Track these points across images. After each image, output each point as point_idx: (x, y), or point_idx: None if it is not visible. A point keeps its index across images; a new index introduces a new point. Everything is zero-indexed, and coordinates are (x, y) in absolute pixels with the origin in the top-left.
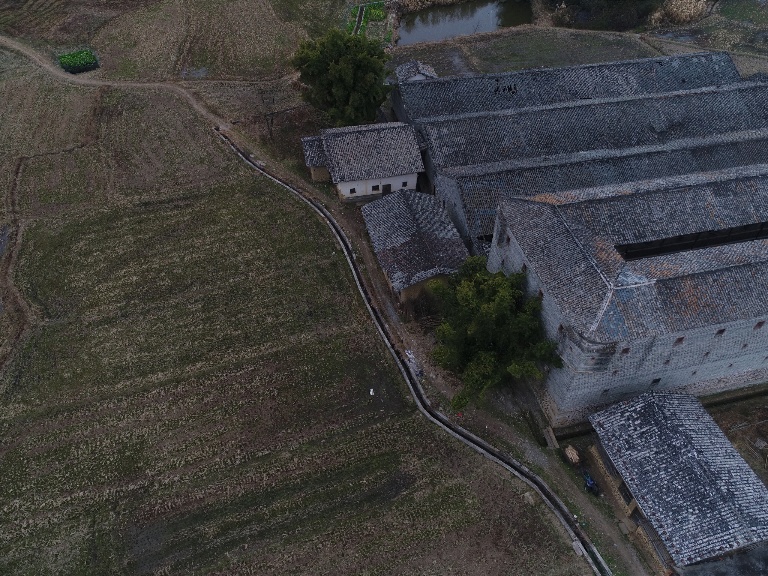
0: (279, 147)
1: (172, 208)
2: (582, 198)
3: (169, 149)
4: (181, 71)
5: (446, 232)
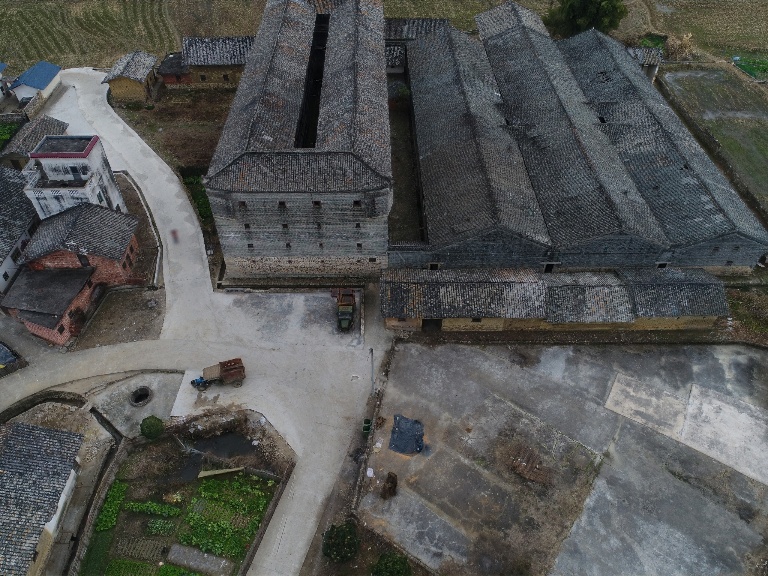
0: (548, 27)
1: (482, 1)
2: (365, 2)
3: (547, 1)
4: (667, 5)
5: (409, 32)
